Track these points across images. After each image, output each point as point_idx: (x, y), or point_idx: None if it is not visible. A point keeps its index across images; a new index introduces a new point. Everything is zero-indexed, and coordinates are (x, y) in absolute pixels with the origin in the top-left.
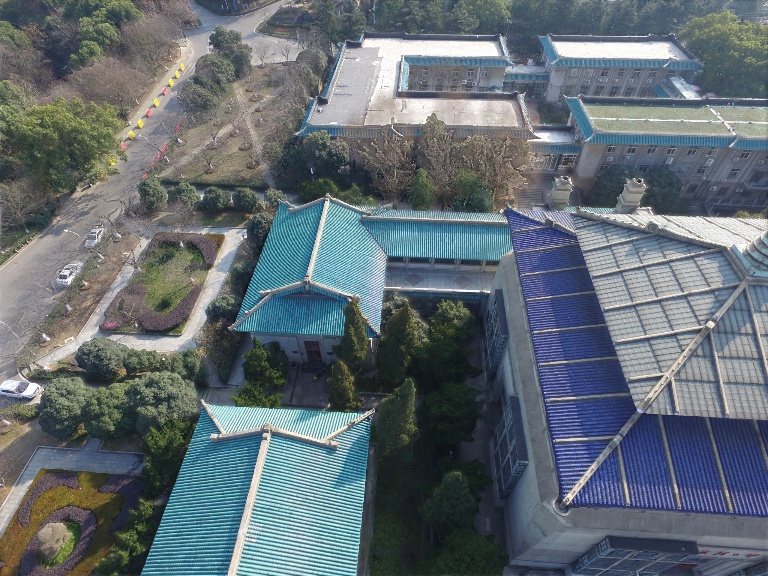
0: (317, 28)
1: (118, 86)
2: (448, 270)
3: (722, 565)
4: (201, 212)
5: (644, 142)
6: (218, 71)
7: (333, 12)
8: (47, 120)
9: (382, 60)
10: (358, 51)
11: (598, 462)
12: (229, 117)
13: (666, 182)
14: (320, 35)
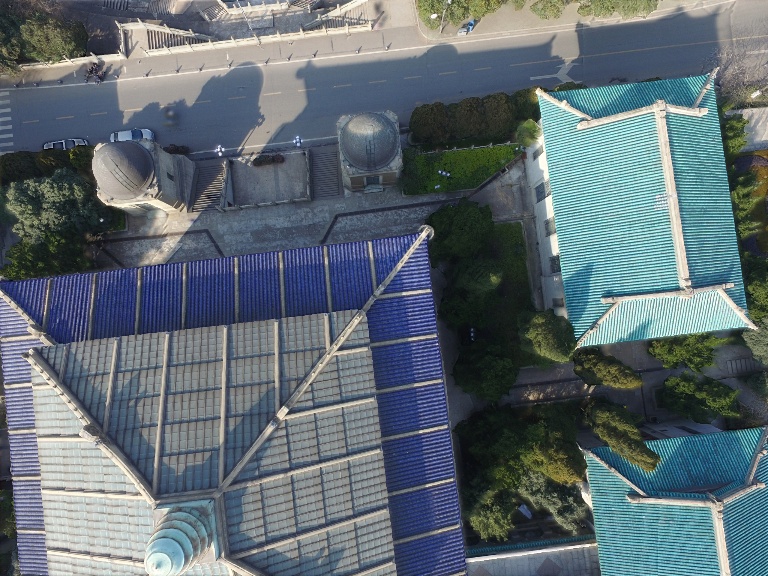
0: None
1: None
2: None
3: None
4: None
5: None
6: None
7: None
8: None
9: None
10: None
11: (396, 270)
12: None
13: None
14: None
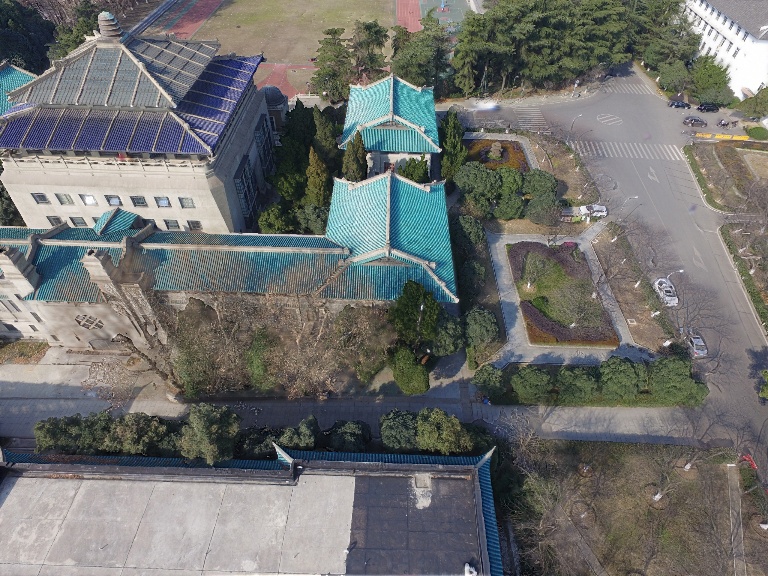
0: None
1: None
2: None
3: None
4: None
5: None
6: None
7: None
8: None
9: None
10: None
11: None
12: None
13: None
14: None
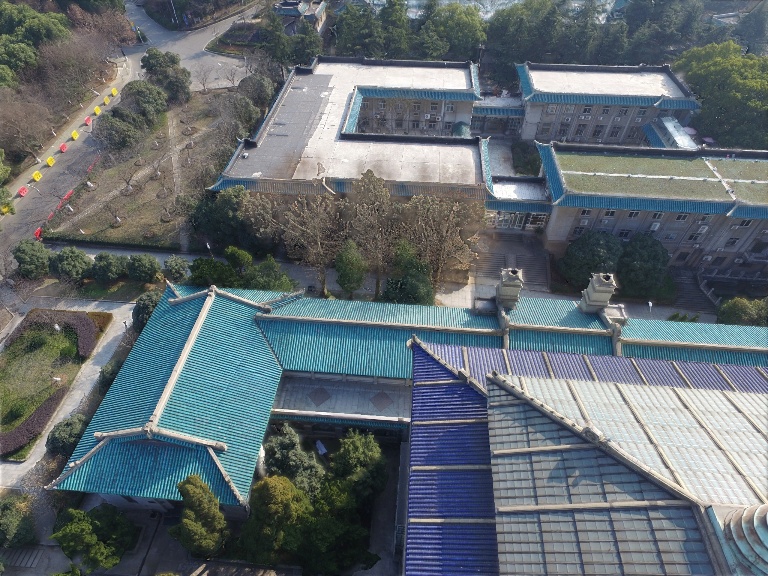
0: (262, 52)
1: (16, 121)
2: (365, 383)
3: None
4: (94, 280)
5: (624, 206)
6: (145, 101)
7: (284, 33)
8: None
9: (332, 91)
10: (308, 79)
11: None
12: (154, 154)
13: (650, 255)
14: (266, 59)
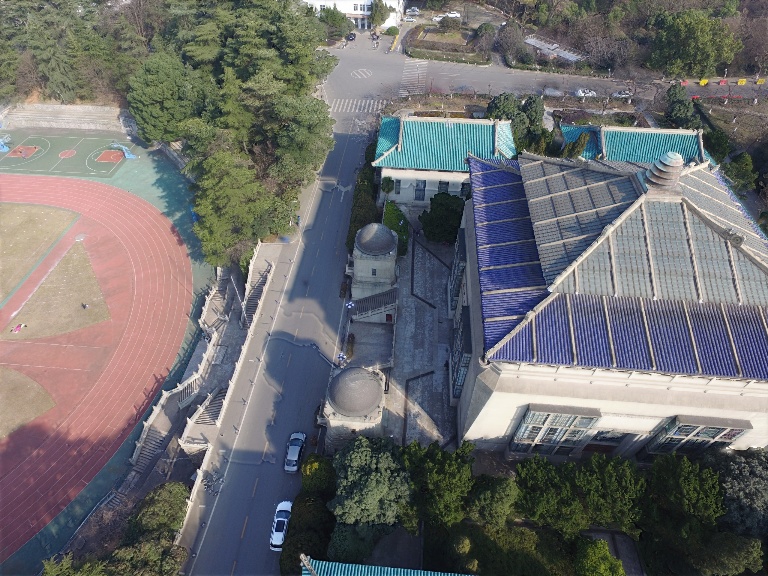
0: None
1: None
2: None
3: None
4: None
5: None
6: None
7: None
8: (692, 24)
9: None
10: None
11: None
12: None
13: None
14: None
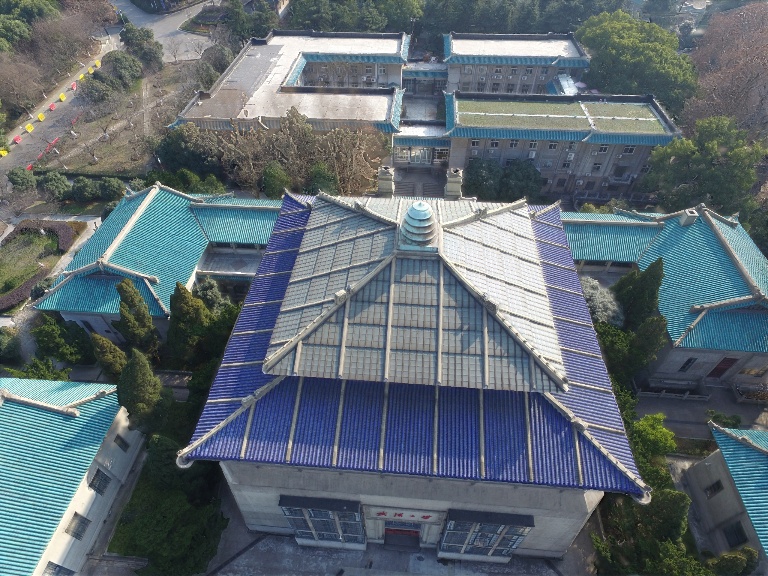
0: (223, 26)
1: (11, 80)
2: None
3: (424, 529)
4: (74, 201)
5: (502, 136)
6: (121, 67)
7: (243, 10)
8: None
9: (281, 57)
10: (262, 48)
11: (227, 419)
12: (129, 111)
13: (524, 175)
14: (227, 32)
